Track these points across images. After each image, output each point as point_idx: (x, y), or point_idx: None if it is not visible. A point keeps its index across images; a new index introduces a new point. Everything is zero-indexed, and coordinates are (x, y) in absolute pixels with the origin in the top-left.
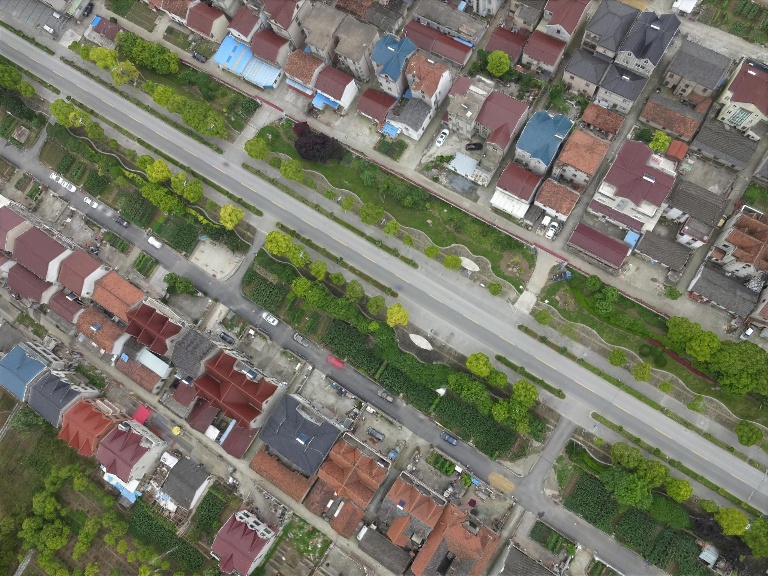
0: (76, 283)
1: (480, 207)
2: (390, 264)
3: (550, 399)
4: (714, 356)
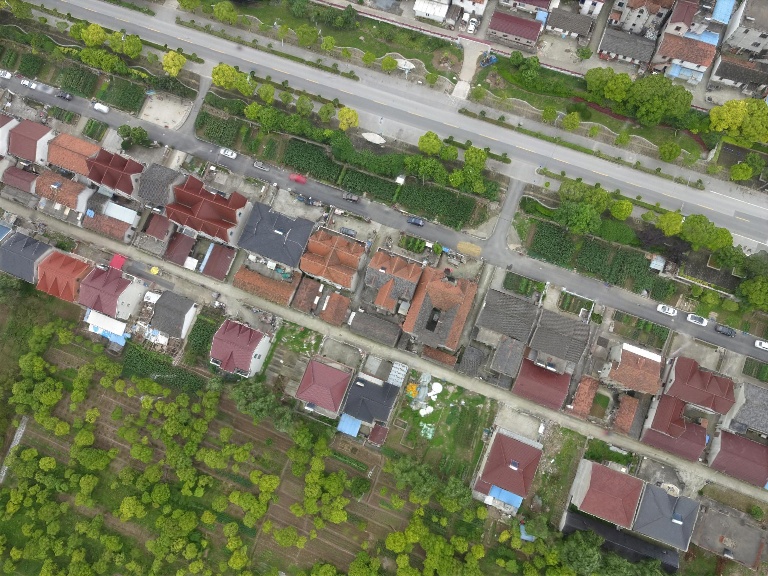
0: (28, 149)
1: (405, 19)
2: (333, 82)
3: (498, 166)
4: (629, 92)
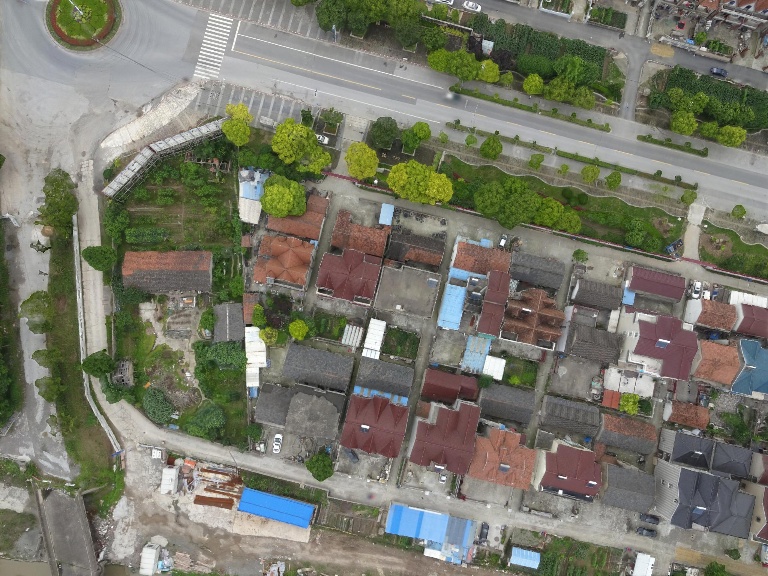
0: None
1: None
2: None
3: (649, 132)
4: (541, 203)
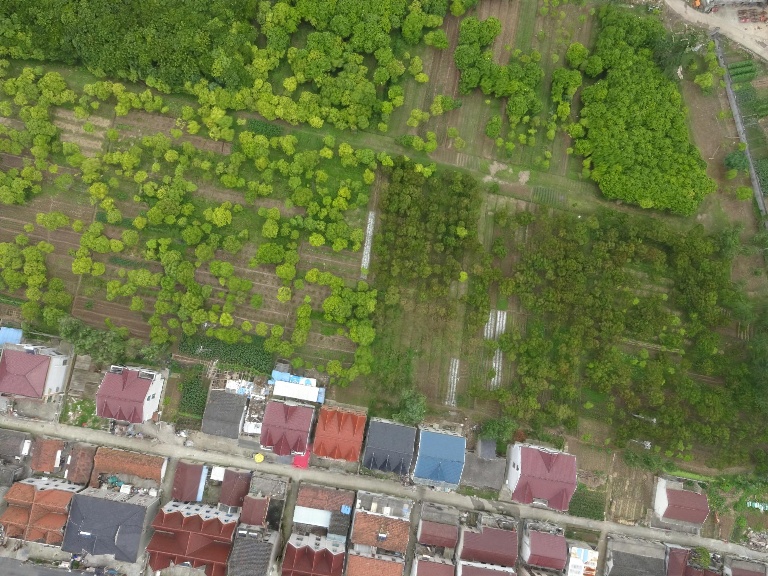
0: None
1: None
2: None
3: None
4: None
